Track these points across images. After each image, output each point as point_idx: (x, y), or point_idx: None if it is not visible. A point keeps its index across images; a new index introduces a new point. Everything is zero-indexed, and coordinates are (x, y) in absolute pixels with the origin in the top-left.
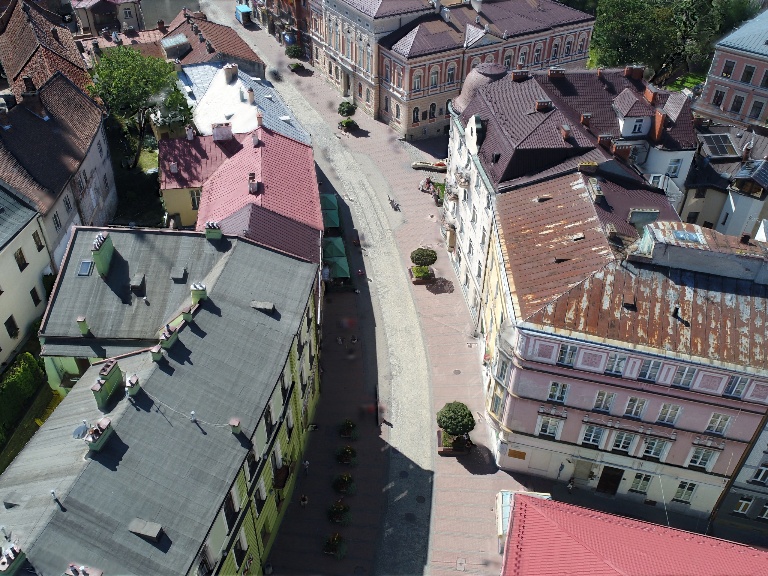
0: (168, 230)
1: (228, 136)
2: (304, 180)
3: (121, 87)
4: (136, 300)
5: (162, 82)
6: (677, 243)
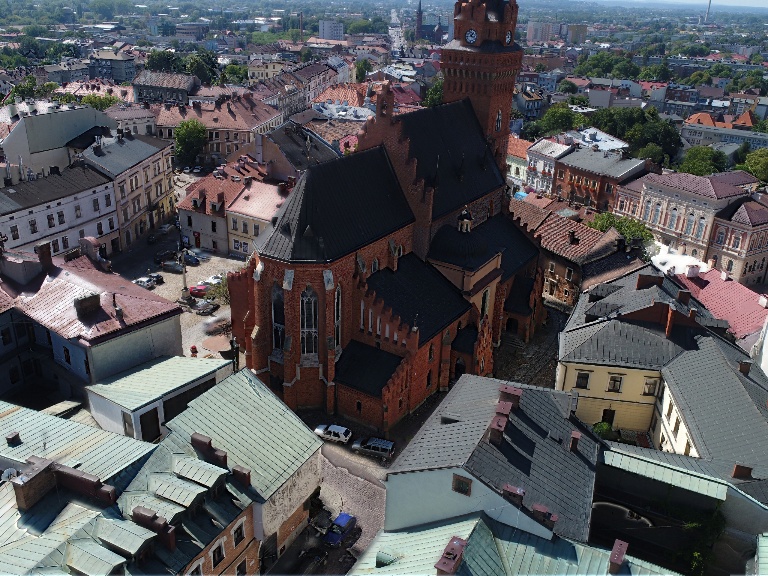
0: None
1: (696, 274)
2: None
3: None
4: None
5: (650, 236)
6: None
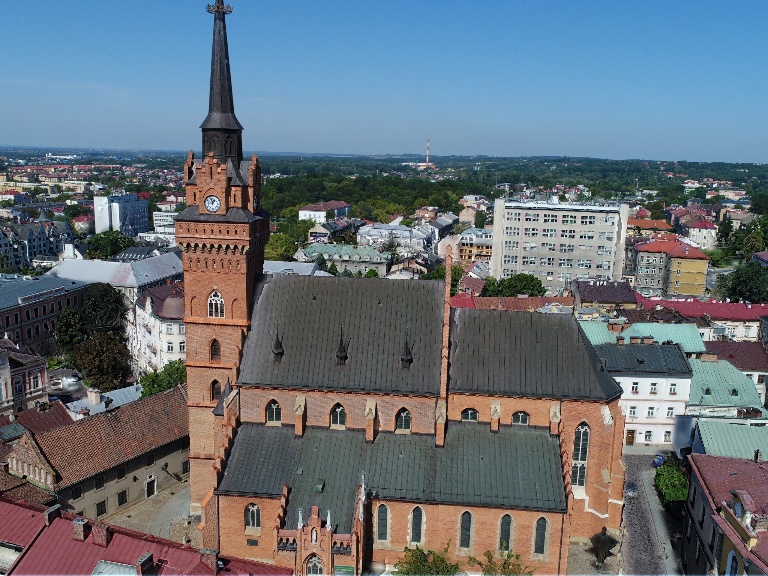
0: None
1: None
2: None
3: None
4: None
5: None
6: None
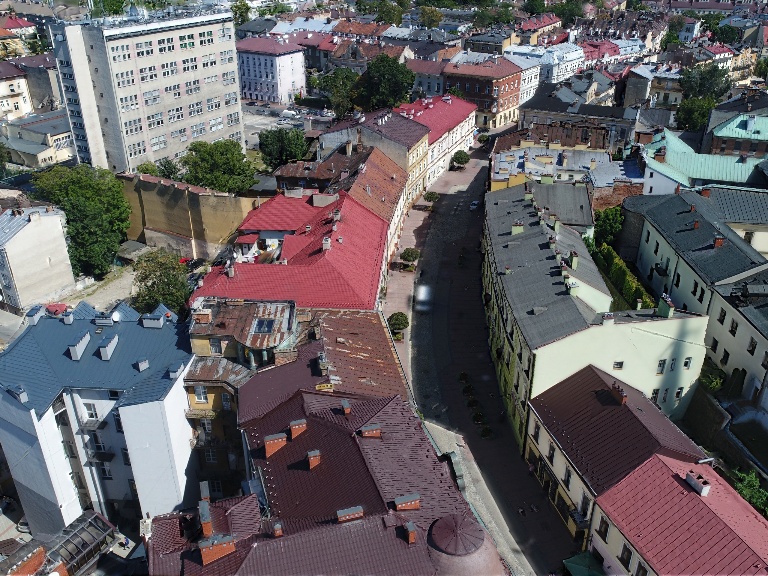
0: (642, 321)
1: None
2: (682, 571)
3: None
4: (625, 315)
5: None
6: (277, 314)
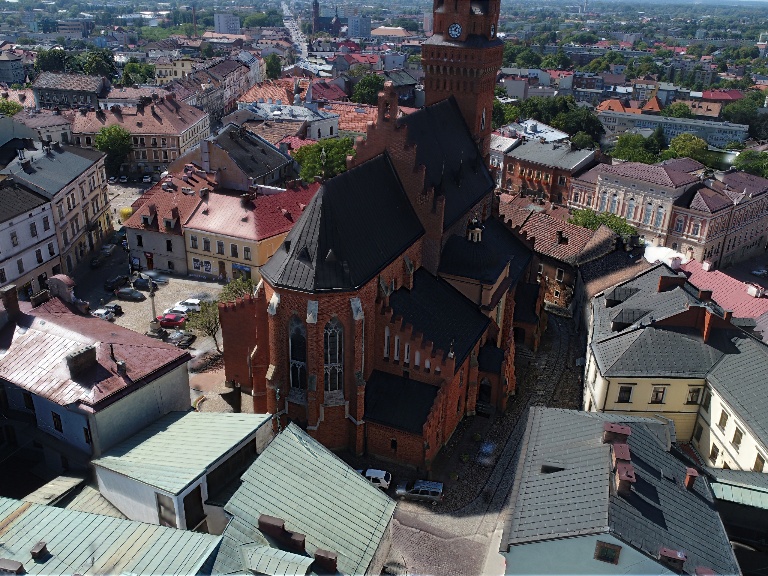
0: None
1: (678, 266)
2: None
3: (620, 234)
4: None
5: None
6: None
